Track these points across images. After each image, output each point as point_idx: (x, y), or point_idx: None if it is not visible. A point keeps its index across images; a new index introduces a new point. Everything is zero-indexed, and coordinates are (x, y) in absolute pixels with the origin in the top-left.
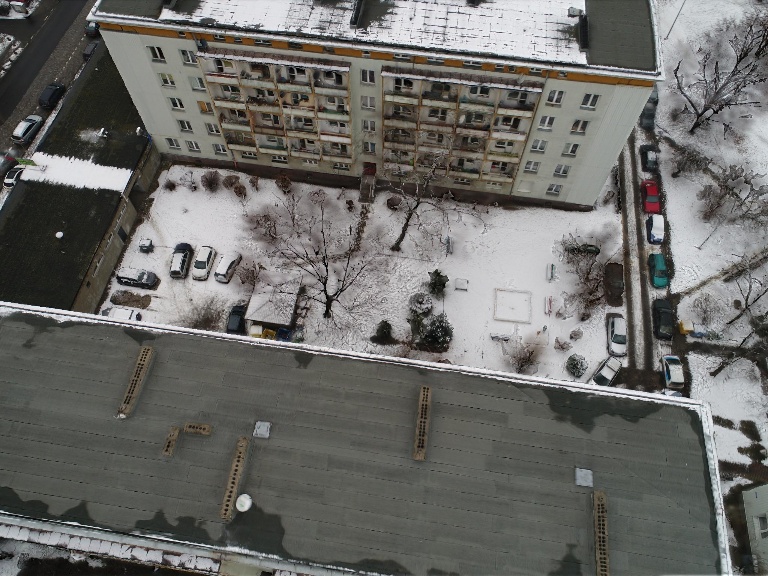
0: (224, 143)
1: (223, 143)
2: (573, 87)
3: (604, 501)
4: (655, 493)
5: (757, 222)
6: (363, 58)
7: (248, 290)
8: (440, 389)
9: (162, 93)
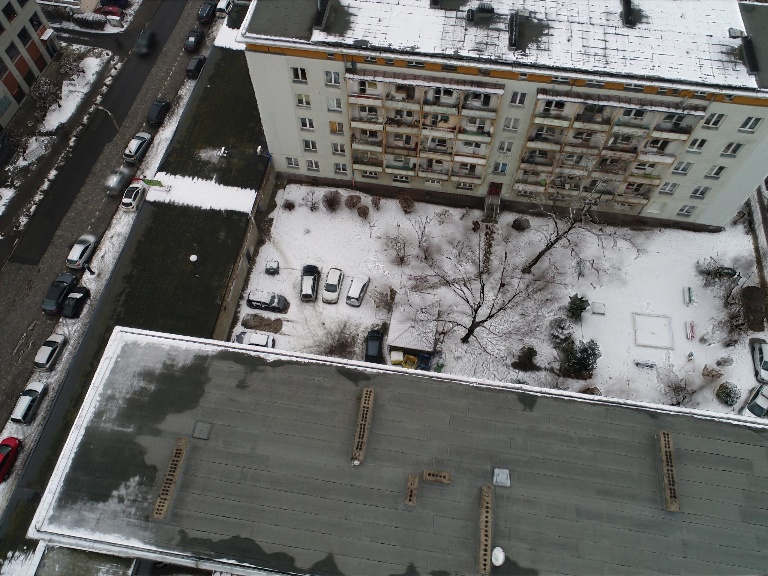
0: (347, 163)
1: (346, 163)
2: (737, 110)
3: None
4: None
5: None
6: (519, 80)
7: (381, 314)
8: (675, 434)
9: (295, 113)
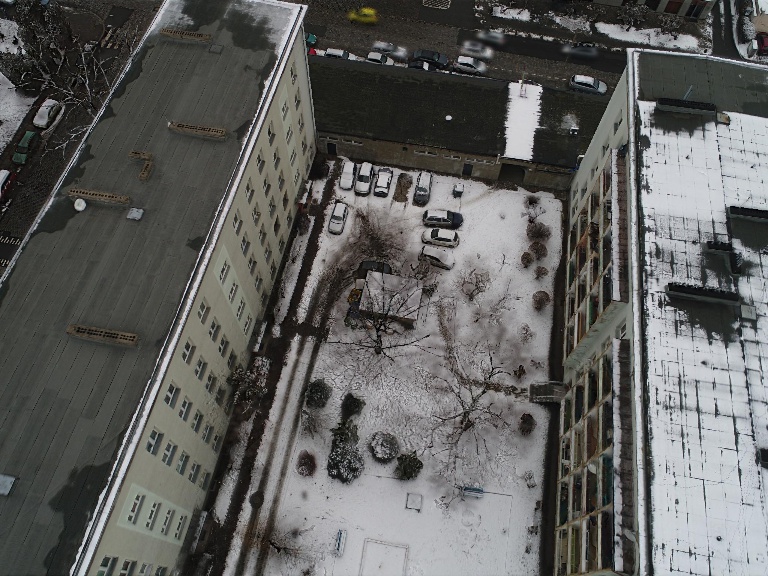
0: None
1: None
2: None
3: None
4: None
5: None
6: None
7: None
8: (137, 357)
9: None
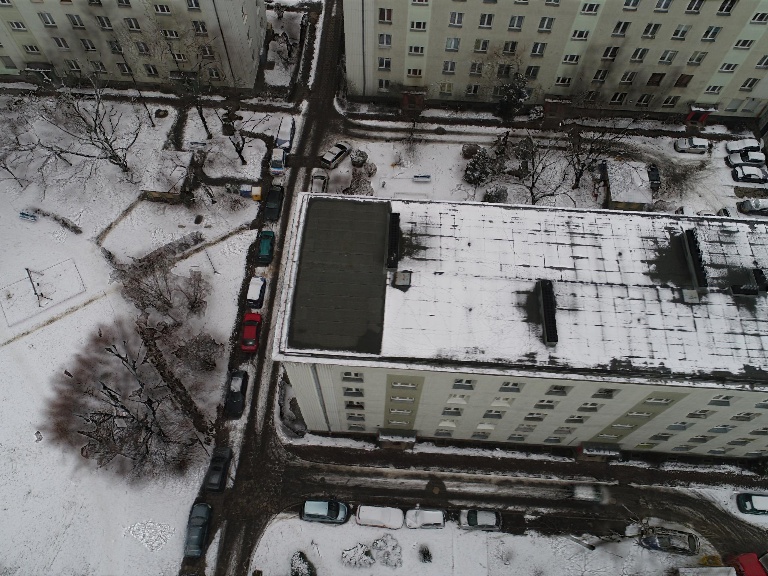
0: None
1: None
2: None
3: None
4: None
5: None
6: None
7: None
8: None
9: None
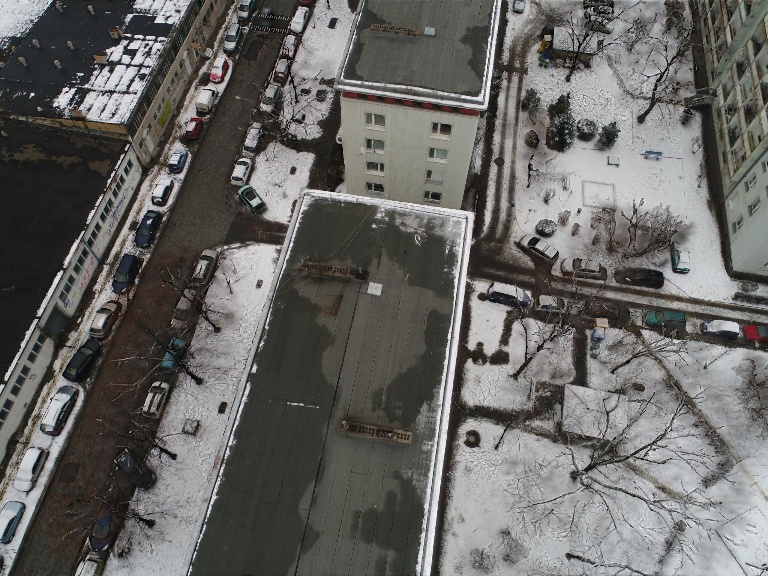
0: None
1: None
2: None
3: (415, 32)
4: (421, 61)
5: (747, 396)
6: None
7: None
8: None
9: None
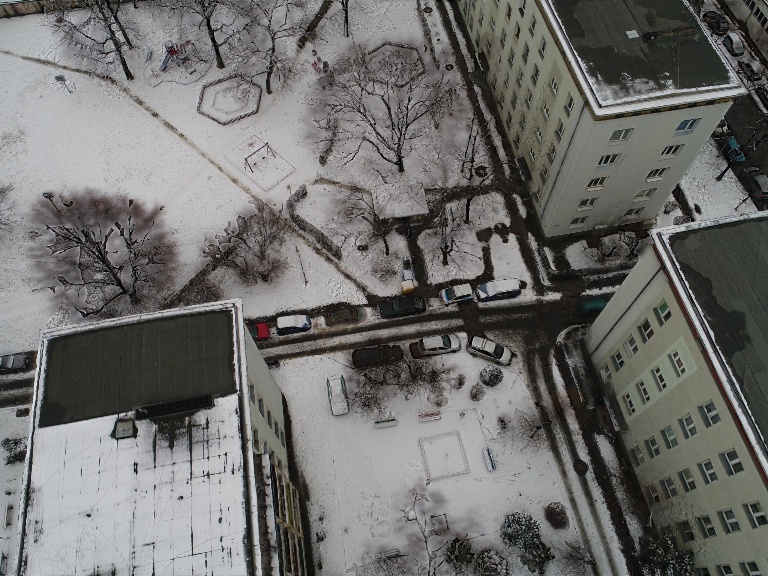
0: None
1: None
2: None
3: None
4: (763, 259)
5: None
6: None
7: None
8: None
9: None
